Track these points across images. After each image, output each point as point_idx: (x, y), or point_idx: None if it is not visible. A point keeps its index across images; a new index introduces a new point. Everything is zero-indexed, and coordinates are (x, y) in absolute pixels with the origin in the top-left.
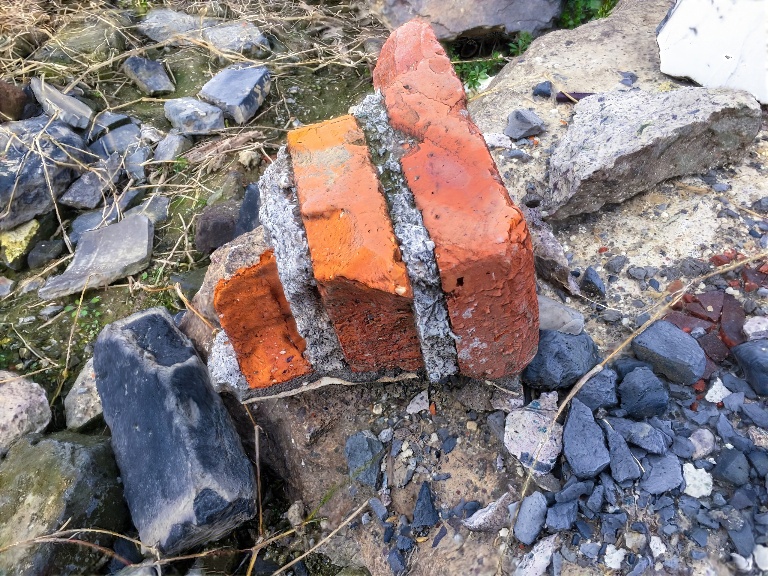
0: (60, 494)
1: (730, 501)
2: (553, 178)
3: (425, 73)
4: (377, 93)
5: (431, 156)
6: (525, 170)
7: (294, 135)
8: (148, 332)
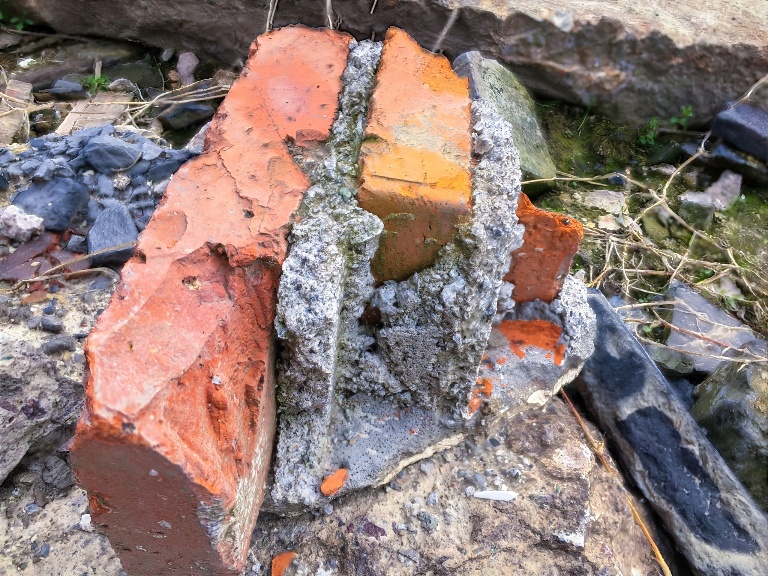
0: (762, 399)
1: (187, 157)
2: (7, 459)
3: (202, 224)
4: (291, 264)
5: (292, 117)
6: (4, 551)
7: (460, 187)
8: (708, 508)
